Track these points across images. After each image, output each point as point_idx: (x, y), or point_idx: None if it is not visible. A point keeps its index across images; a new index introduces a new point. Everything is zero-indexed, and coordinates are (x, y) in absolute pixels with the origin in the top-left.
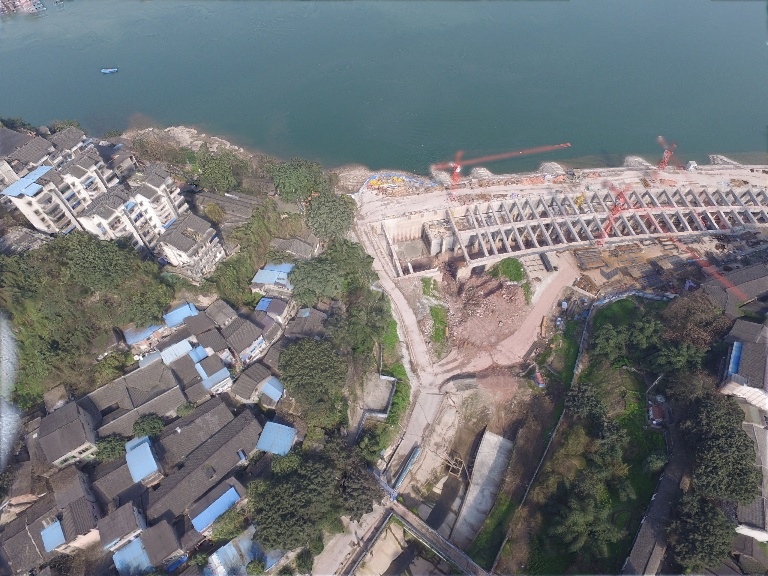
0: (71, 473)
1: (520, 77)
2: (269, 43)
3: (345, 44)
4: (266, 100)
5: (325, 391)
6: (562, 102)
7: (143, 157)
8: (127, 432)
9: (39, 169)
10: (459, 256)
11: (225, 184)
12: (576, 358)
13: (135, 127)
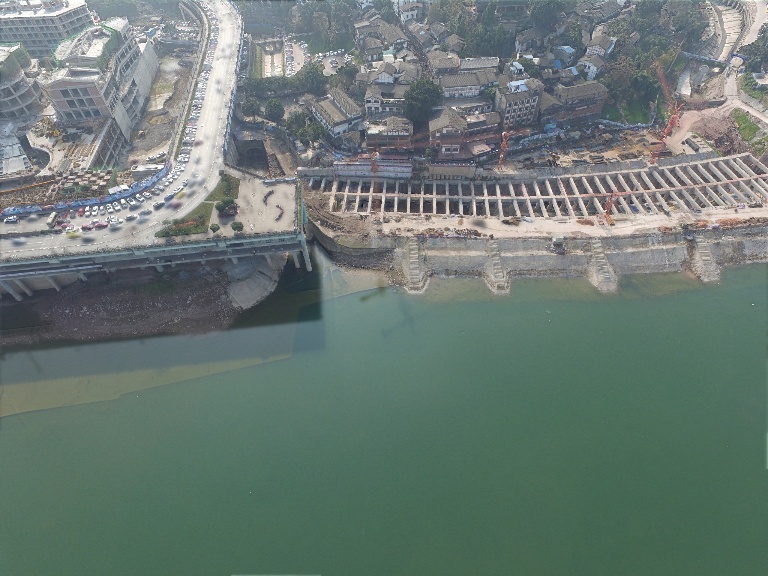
0: None
1: None
2: None
3: None
4: None
5: None
6: (733, 423)
7: None
8: None
9: None
10: None
11: None
12: (657, 104)
13: None
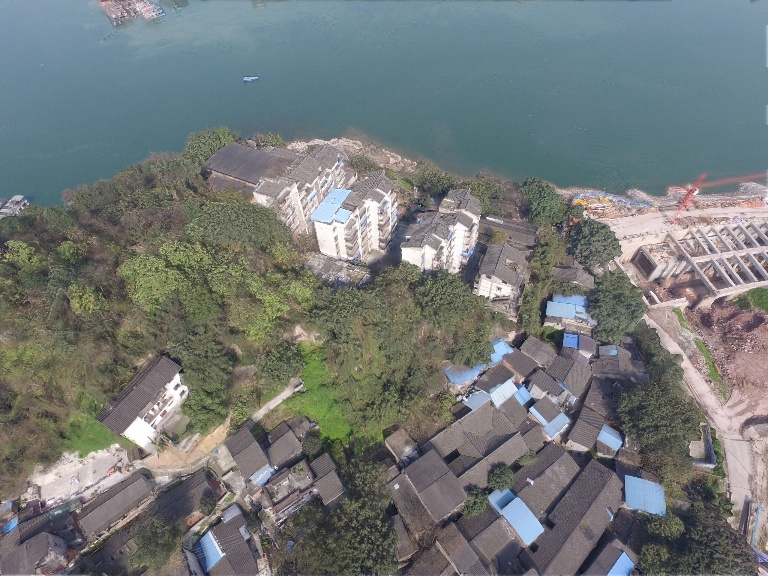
0: (455, 532)
1: (681, 90)
2: (405, 52)
3: (483, 53)
4: (423, 111)
5: (688, 444)
6: (736, 117)
7: (361, 174)
8: (482, 483)
9: (335, 192)
10: (681, 282)
11: (482, 207)
12: None
13: (296, 138)
